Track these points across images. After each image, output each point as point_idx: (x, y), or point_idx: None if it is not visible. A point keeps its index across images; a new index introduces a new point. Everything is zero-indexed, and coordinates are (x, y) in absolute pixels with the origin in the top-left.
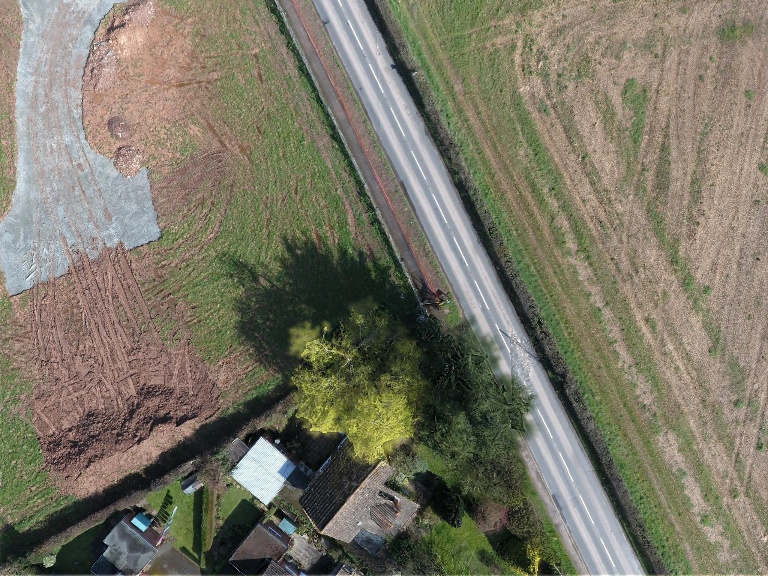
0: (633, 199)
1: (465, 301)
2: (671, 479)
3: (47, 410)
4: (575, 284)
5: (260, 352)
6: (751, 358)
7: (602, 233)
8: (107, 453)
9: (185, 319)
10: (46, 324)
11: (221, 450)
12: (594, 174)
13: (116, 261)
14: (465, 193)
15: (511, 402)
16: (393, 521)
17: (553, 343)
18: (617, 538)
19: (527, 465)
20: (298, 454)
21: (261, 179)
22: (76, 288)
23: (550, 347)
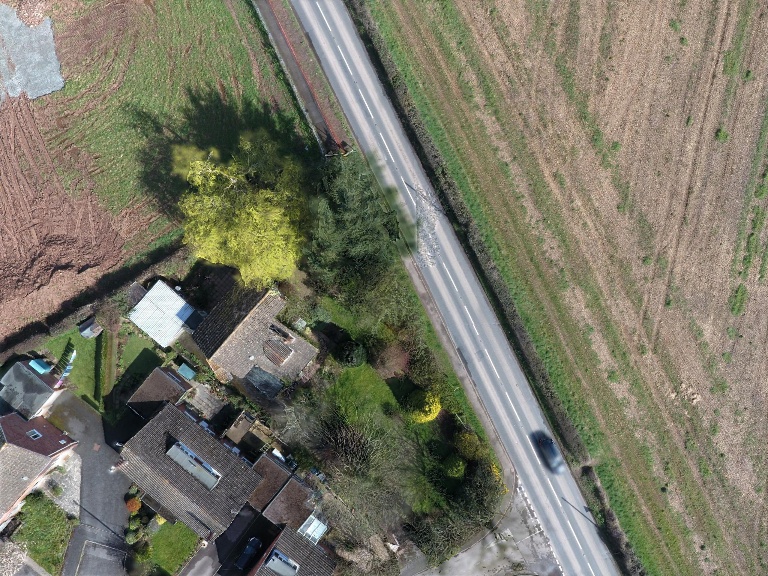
0: (542, 54)
1: (370, 153)
2: (578, 335)
3: None
4: (482, 139)
5: (163, 203)
6: (660, 215)
7: (510, 88)
8: (6, 297)
9: (88, 169)
10: None
11: (119, 292)
12: (502, 28)
13: (18, 110)
14: (370, 44)
15: (416, 255)
16: (286, 356)
17: (457, 193)
18: (522, 392)
19: (432, 318)
20: (197, 298)
21: (165, 29)
22: None
23: (454, 197)
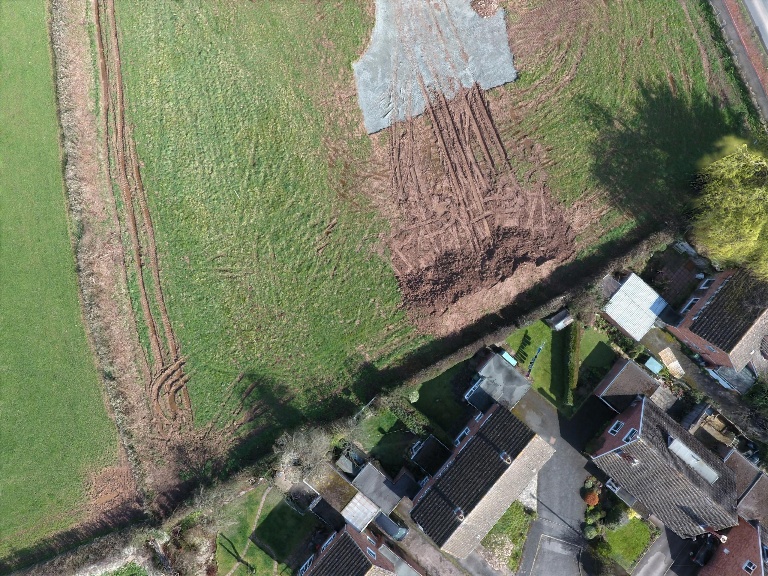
0: None
1: None
2: None
3: (405, 249)
4: None
5: (614, 196)
6: None
7: None
8: (474, 289)
9: (541, 161)
10: (404, 163)
11: (595, 285)
12: None
13: (473, 101)
14: None
15: None
16: None
17: None
18: None
19: None
20: None
21: (617, 22)
22: (434, 127)
23: None
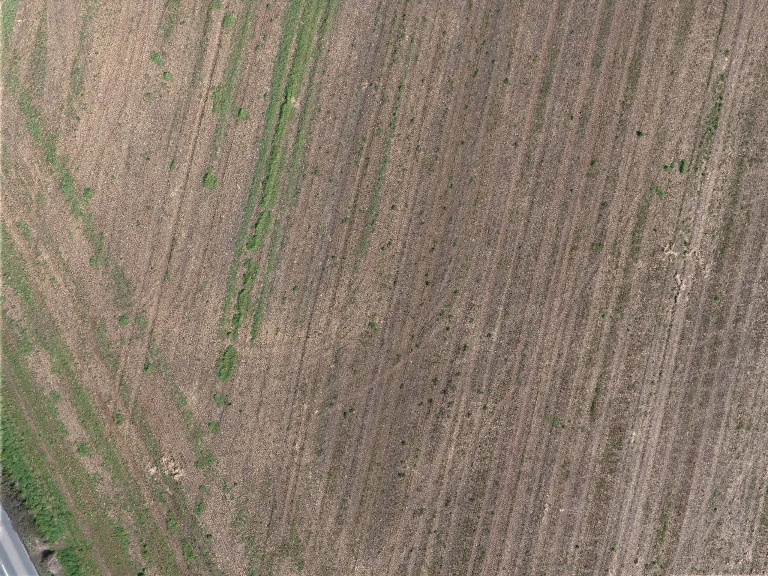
0: (4, 91)
1: None
2: (42, 403)
3: None
4: None
5: None
6: (139, 269)
7: None
8: None
9: None
10: None
11: None
12: None
13: None
14: None
15: None
16: None
17: None
18: None
19: None
20: None
21: None
22: None
23: None
